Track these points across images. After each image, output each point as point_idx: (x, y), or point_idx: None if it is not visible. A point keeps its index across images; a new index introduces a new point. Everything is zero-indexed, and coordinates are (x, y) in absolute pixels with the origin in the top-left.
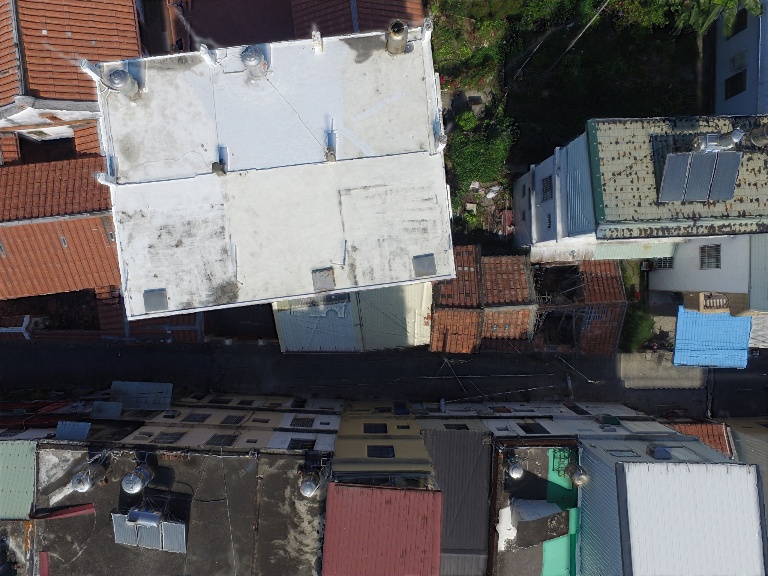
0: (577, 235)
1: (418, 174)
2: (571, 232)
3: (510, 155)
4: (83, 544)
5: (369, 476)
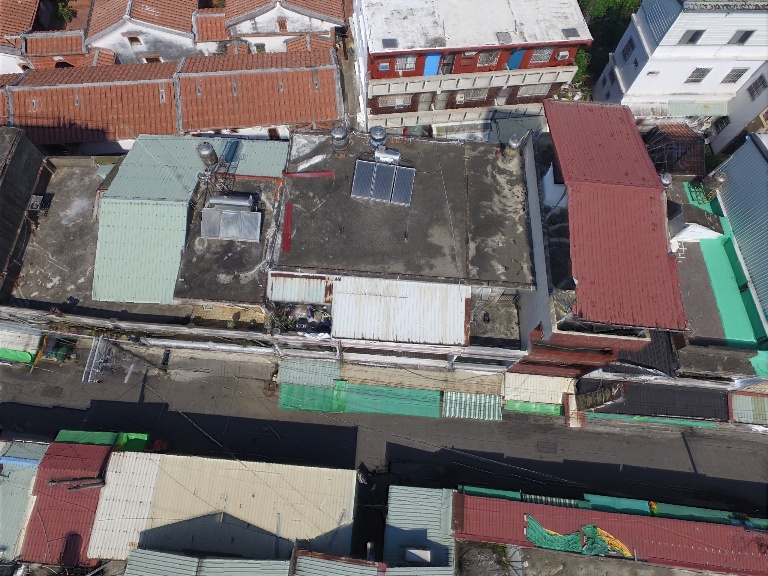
0: (666, 34)
1: None
2: (659, 40)
3: (585, 77)
4: (323, 199)
5: None
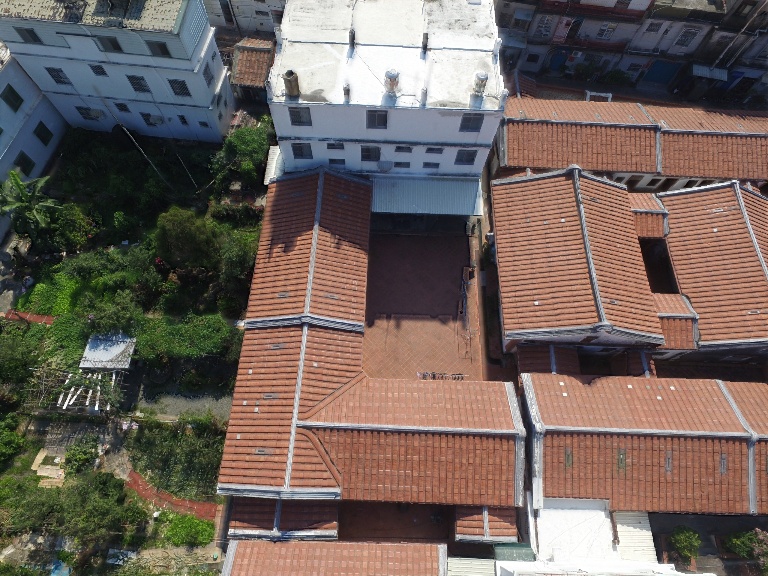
0: None
1: (298, 31)
2: None
3: None
4: None
5: None
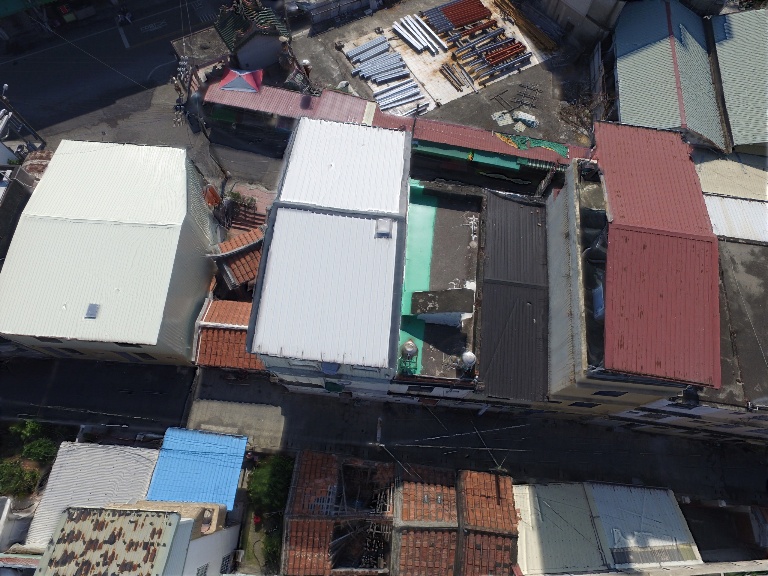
0: None
1: None
2: None
3: None
4: None
5: (649, 380)
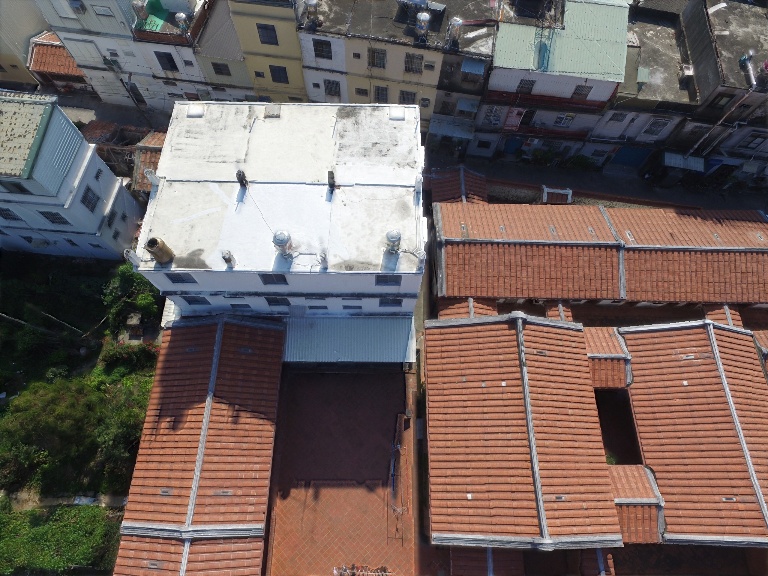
0: None
1: (180, 166)
2: (80, 136)
3: None
4: (467, 8)
5: (270, 3)
